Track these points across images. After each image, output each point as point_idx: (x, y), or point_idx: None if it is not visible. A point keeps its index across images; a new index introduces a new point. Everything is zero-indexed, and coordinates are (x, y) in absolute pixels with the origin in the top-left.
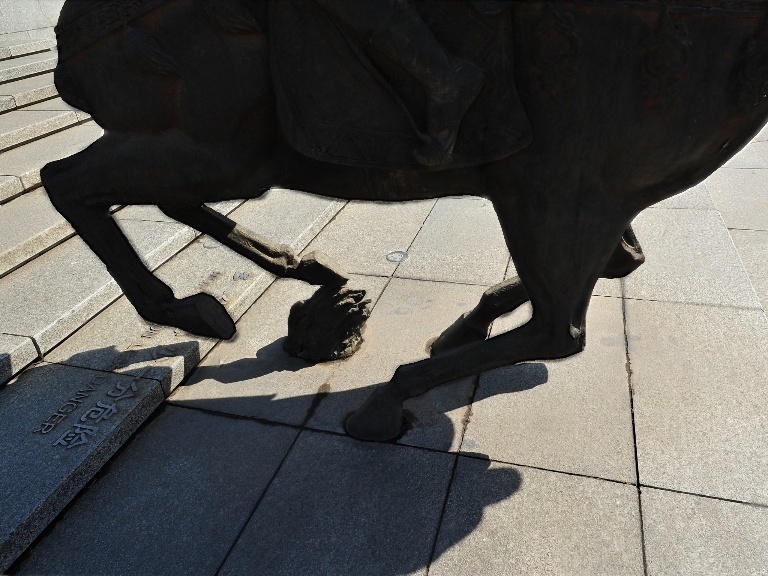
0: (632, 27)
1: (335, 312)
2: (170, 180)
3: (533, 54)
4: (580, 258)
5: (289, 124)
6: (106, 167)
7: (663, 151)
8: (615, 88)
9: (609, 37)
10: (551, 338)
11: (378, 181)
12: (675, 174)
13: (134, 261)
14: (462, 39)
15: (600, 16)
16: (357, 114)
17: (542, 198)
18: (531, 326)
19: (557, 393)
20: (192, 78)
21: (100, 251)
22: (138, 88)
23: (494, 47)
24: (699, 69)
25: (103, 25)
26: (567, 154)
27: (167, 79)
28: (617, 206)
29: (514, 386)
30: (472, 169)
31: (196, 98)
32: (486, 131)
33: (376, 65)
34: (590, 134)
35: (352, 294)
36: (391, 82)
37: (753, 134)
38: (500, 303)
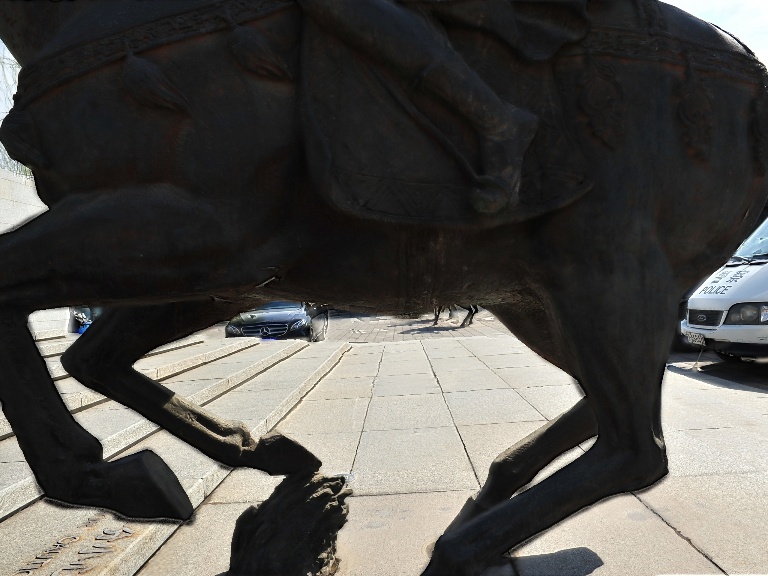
0: (664, 78)
1: (307, 510)
2: (149, 247)
3: (580, 102)
4: (652, 333)
5: (327, 164)
6: (52, 235)
7: (709, 204)
8: (660, 134)
9: (647, 86)
10: (634, 453)
11: (414, 256)
12: (712, 244)
13: (52, 394)
14: (508, 90)
15: (635, 68)
16: (399, 165)
17: (605, 258)
18: (604, 444)
19: (625, 572)
20: (204, 119)
21: (1, 374)
22: (131, 127)
23: (540, 97)
24: (723, 122)
25: (99, 57)
26: (626, 203)
27: (172, 118)
28: (671, 275)
29: (568, 574)
30: (521, 236)
31: (206, 141)
32: (543, 179)
33: (422, 112)
34: (645, 181)
35: (328, 483)
36: (439, 128)
37: (762, 208)
38: (518, 469)
